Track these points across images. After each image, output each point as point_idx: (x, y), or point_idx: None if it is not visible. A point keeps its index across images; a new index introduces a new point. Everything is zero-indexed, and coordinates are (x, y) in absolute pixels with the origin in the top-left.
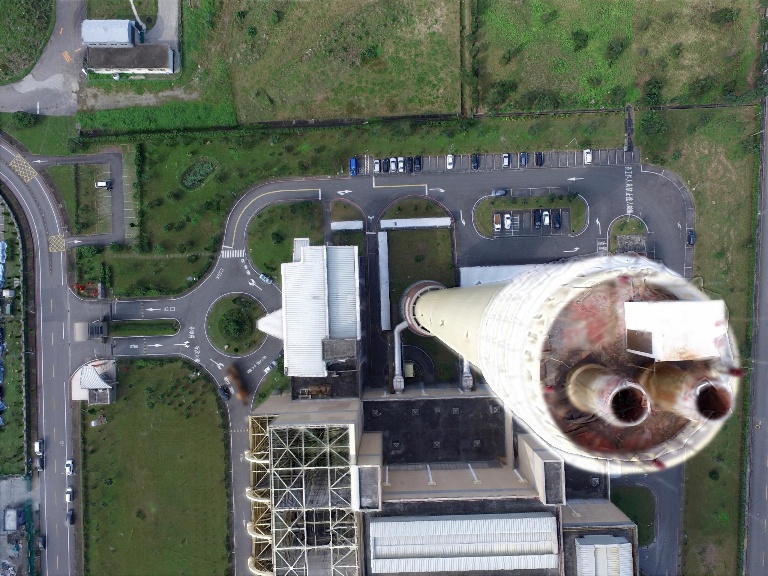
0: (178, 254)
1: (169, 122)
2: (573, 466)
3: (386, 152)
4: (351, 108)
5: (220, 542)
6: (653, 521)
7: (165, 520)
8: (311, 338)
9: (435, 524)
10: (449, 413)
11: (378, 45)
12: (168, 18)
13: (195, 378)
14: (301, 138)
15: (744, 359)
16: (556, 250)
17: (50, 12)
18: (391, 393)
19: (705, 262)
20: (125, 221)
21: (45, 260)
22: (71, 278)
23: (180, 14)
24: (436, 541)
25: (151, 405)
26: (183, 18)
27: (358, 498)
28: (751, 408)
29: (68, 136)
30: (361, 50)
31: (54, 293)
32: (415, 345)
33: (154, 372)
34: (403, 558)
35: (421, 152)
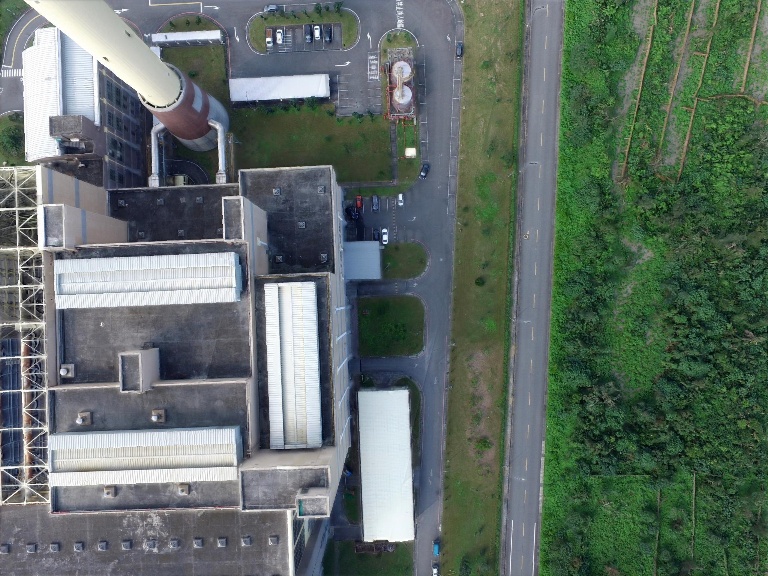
0: None
1: None
2: (303, 243)
3: None
4: None
5: None
6: (422, 329)
7: None
8: (44, 119)
9: (117, 260)
10: (194, 203)
11: None
12: None
13: None
14: None
15: (511, 168)
16: (328, 64)
17: None
18: None
19: (473, 74)
20: None
21: None
22: None
23: None
24: (120, 278)
25: None
26: None
27: (43, 236)
28: (519, 218)
29: None
30: None
31: None
32: (190, 160)
33: None
34: (86, 294)
35: None
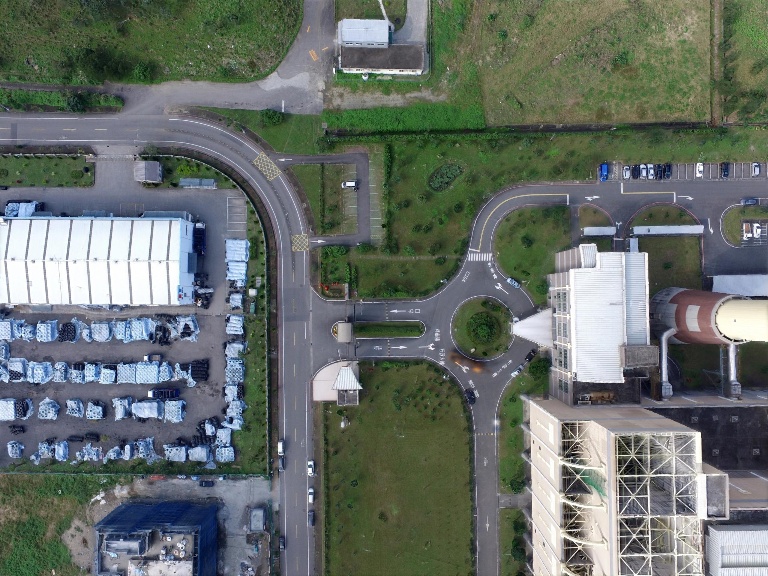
0: (424, 256)
1: (417, 123)
2: None
3: (636, 159)
4: (601, 114)
5: (463, 545)
6: None
7: (408, 523)
8: (607, 344)
9: None
10: (727, 421)
11: (629, 51)
12: (417, 19)
13: (441, 381)
14: (550, 143)
15: None
16: None
17: (298, 10)
18: (657, 400)
19: None
20: (371, 222)
21: (288, 259)
22: (314, 278)
23: (430, 15)
24: None
25: (399, 407)
26: (432, 19)
27: (706, 506)
28: None
29: (313, 135)
30: (612, 56)
31: (297, 293)
32: None
33: (398, 374)
34: (750, 567)
35: (671, 159)
